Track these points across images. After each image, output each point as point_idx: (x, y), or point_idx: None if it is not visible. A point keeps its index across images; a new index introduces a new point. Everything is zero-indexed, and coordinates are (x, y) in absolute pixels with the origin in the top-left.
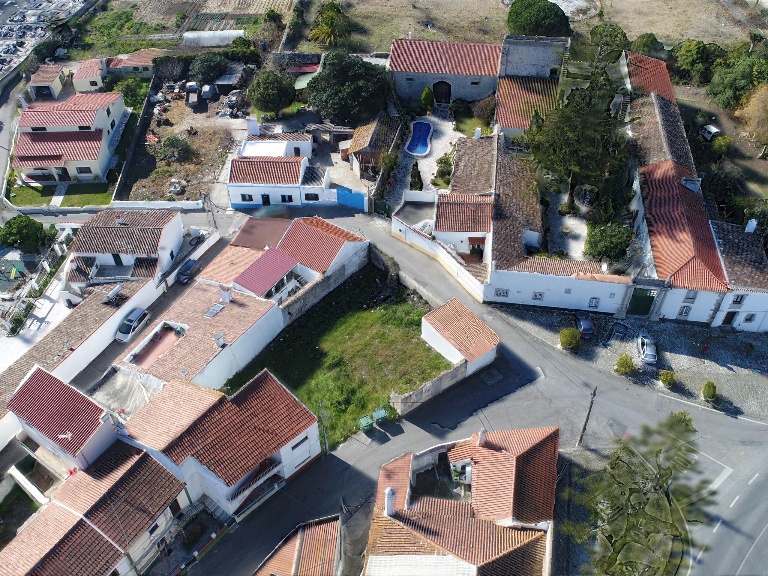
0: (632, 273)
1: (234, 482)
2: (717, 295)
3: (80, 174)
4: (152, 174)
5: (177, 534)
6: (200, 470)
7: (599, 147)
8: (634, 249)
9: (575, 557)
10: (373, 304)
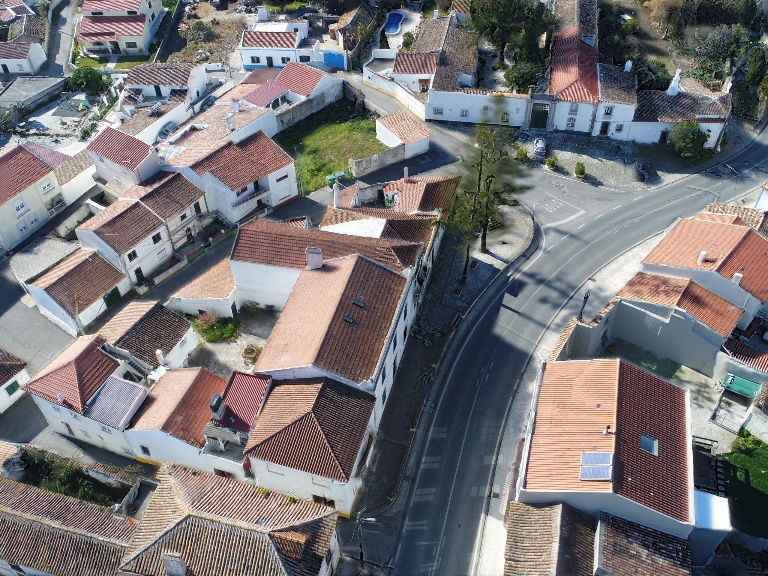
0: (529, 89)
1: (237, 189)
2: (592, 107)
3: (128, 48)
4: (183, 49)
5: (199, 232)
6: (215, 184)
7: (516, 8)
8: (542, 86)
9: (462, 245)
10: (344, 120)
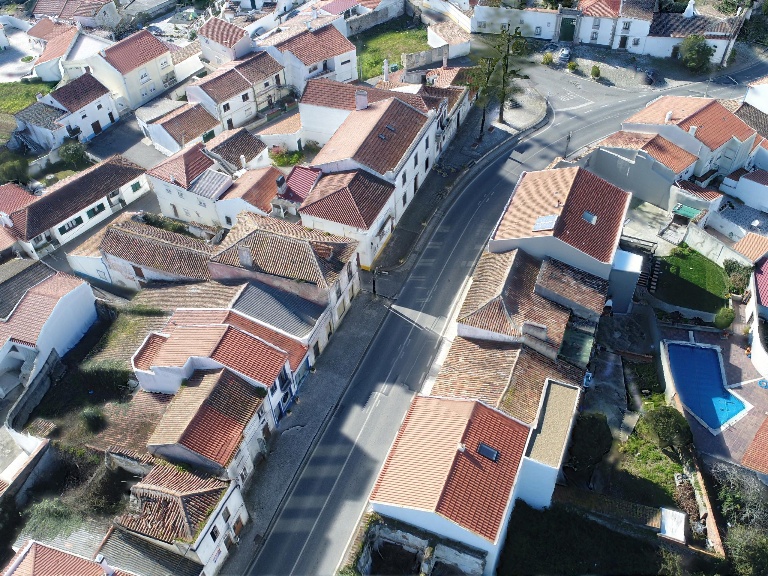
0: (559, 5)
1: (309, 65)
2: (613, 22)
3: None
4: None
5: (278, 100)
6: (292, 61)
7: None
8: None
9: (485, 117)
10: (403, 30)
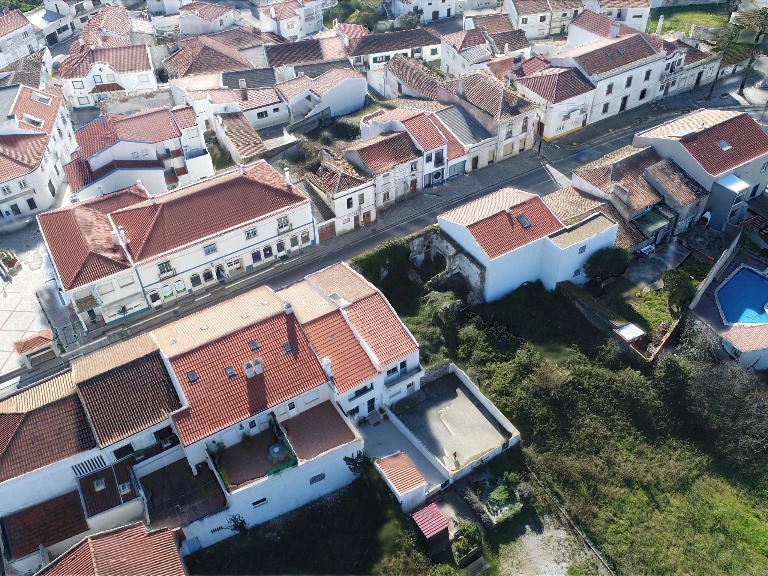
0: None
1: (604, 8)
2: None
3: None
4: None
5: None
6: (593, 3)
7: None
8: None
9: (729, 87)
10: (714, 14)
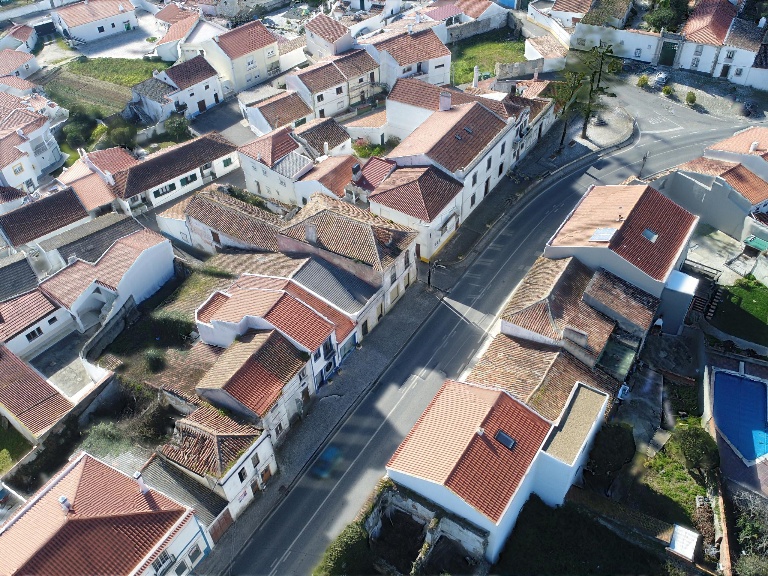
0: (662, 28)
1: (403, 65)
2: (716, 49)
3: None
4: None
5: (370, 96)
6: (388, 60)
7: None
8: None
9: (568, 131)
10: (502, 41)
